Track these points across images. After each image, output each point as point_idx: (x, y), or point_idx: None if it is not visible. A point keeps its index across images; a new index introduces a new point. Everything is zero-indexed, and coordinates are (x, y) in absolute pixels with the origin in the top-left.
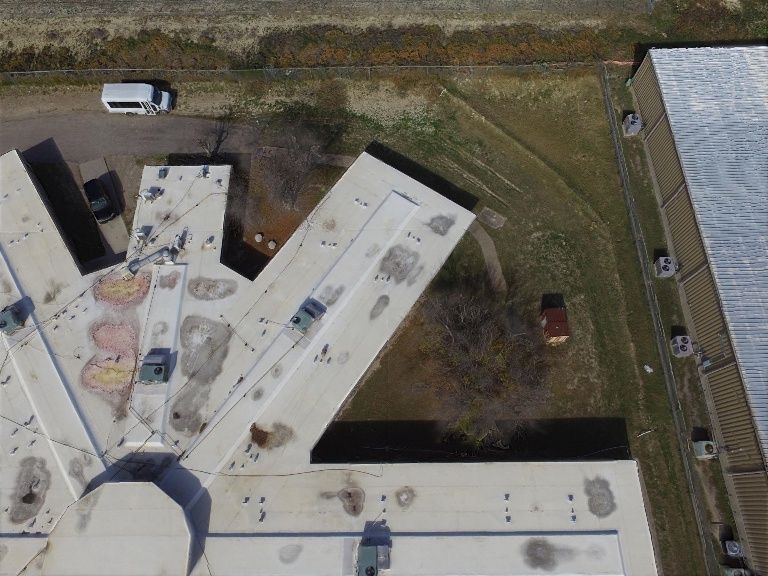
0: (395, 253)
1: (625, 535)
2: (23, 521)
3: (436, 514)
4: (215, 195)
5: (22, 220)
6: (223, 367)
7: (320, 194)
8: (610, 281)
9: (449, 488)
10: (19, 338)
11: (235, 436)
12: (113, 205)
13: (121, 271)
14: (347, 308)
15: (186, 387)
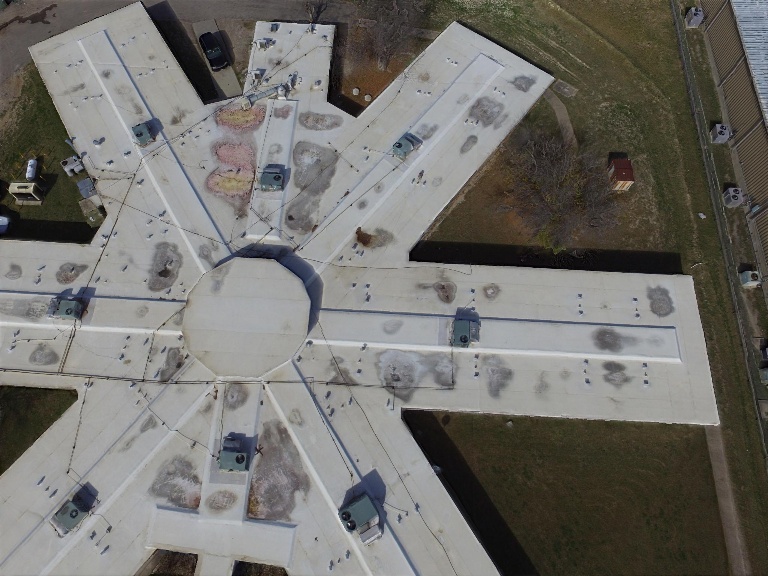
0: (483, 103)
1: (682, 331)
2: (160, 290)
3: (518, 305)
4: (321, 48)
5: (149, 58)
6: (331, 183)
7: (410, 60)
8: (670, 145)
9: (530, 286)
10: (151, 149)
11: (344, 235)
12: (225, 56)
13: (242, 100)
14: (440, 143)
15: (299, 196)
